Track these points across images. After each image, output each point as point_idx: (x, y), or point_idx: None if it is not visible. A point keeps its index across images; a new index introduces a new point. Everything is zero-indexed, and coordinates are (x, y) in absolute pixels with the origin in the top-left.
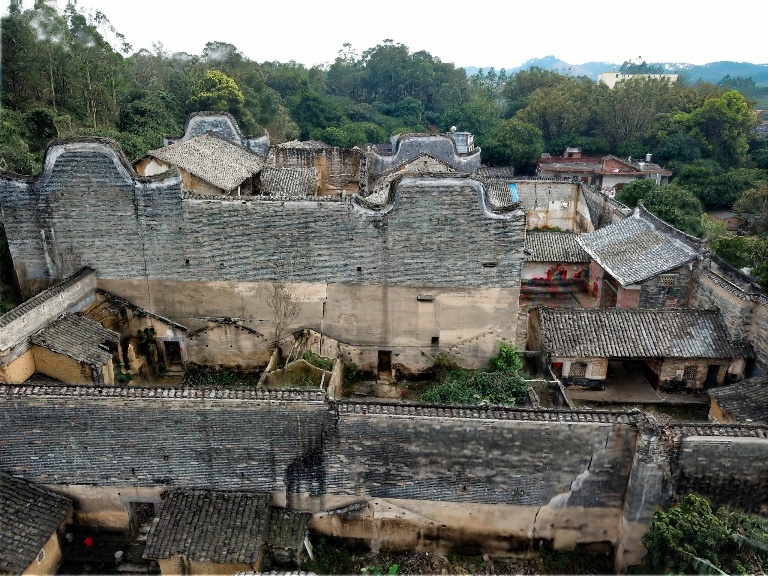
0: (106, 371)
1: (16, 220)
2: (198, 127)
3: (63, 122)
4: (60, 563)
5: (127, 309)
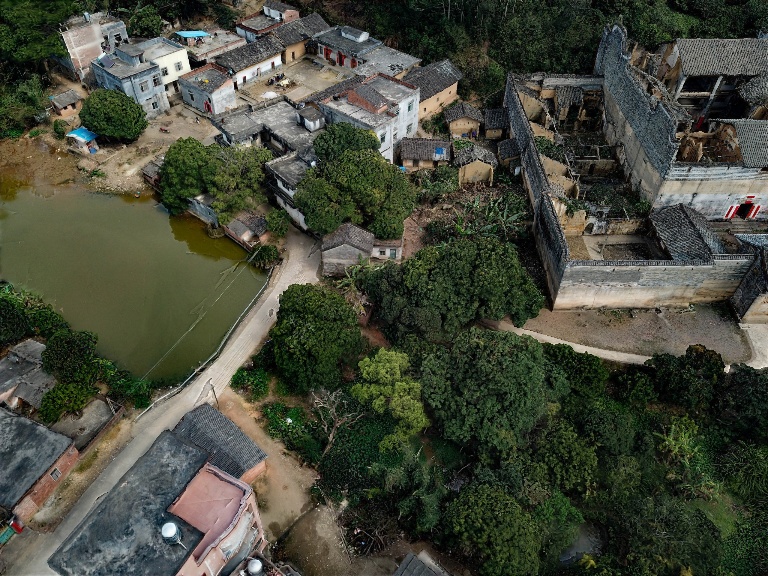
0: (563, 110)
1: (601, 45)
2: None
3: None
4: (499, 139)
5: None
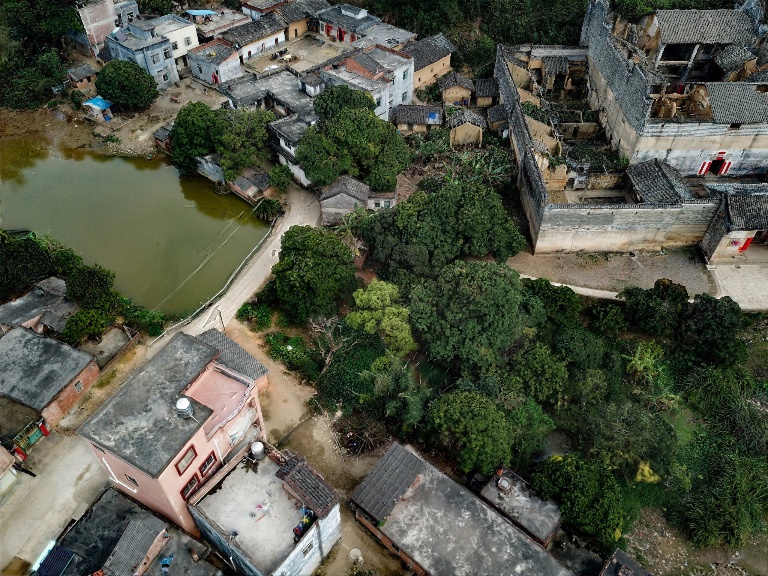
0: (550, 79)
1: (586, 18)
2: (750, 3)
3: None
4: (490, 106)
5: (587, 68)
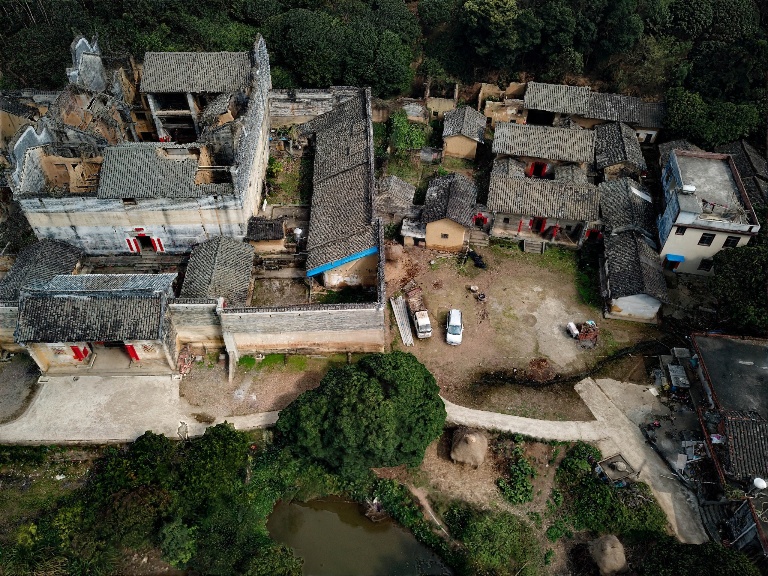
0: None
1: None
2: None
3: None
4: None
5: None
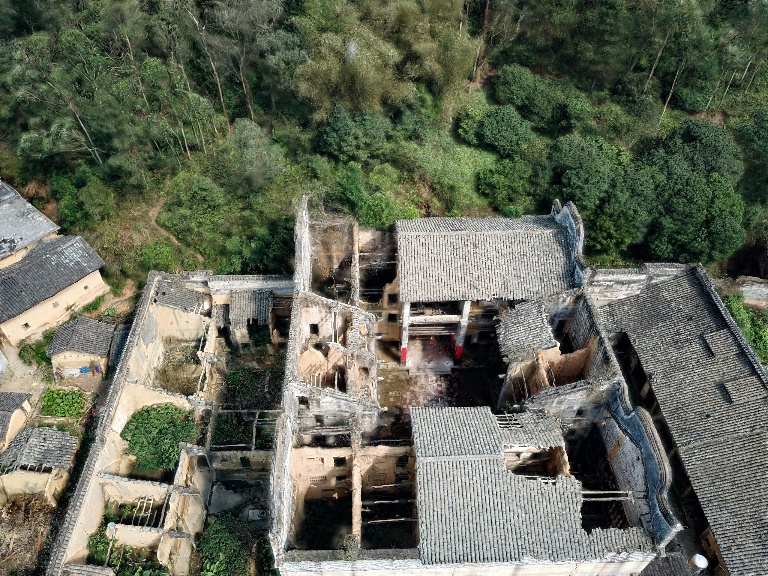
0: (238, 332)
1: None
2: None
3: (292, 202)
4: None
5: None
